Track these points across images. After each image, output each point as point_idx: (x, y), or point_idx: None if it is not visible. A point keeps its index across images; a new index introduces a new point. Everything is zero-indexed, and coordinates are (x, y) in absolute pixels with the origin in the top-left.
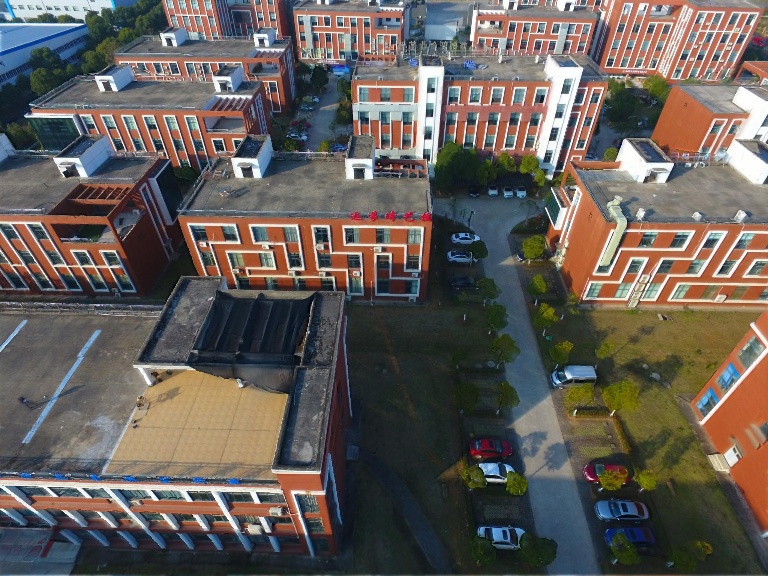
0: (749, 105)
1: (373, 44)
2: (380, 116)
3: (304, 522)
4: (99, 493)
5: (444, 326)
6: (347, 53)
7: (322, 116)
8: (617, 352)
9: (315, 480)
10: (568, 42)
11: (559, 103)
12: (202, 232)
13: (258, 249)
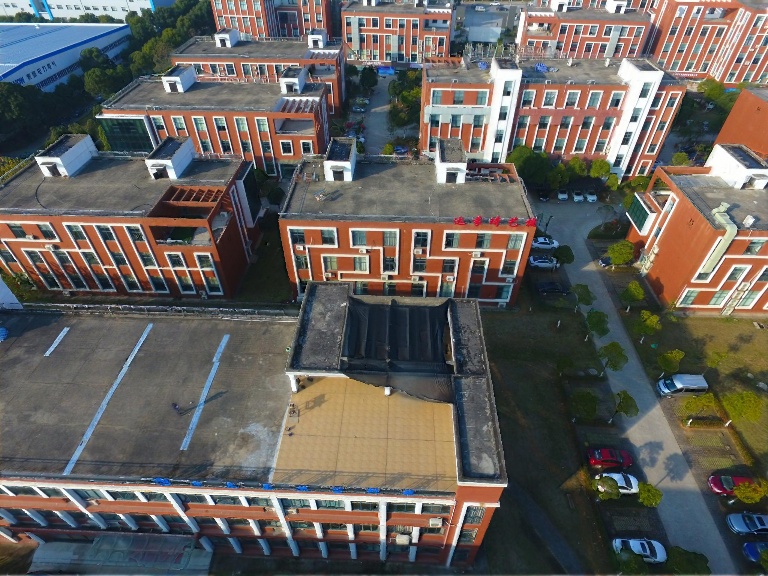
0: None
1: (420, 46)
2: (451, 119)
3: (459, 533)
4: (258, 501)
5: (538, 332)
6: (393, 55)
7: (374, 118)
8: (719, 361)
9: (496, 493)
10: (619, 45)
11: (636, 107)
12: (300, 235)
13: (354, 253)
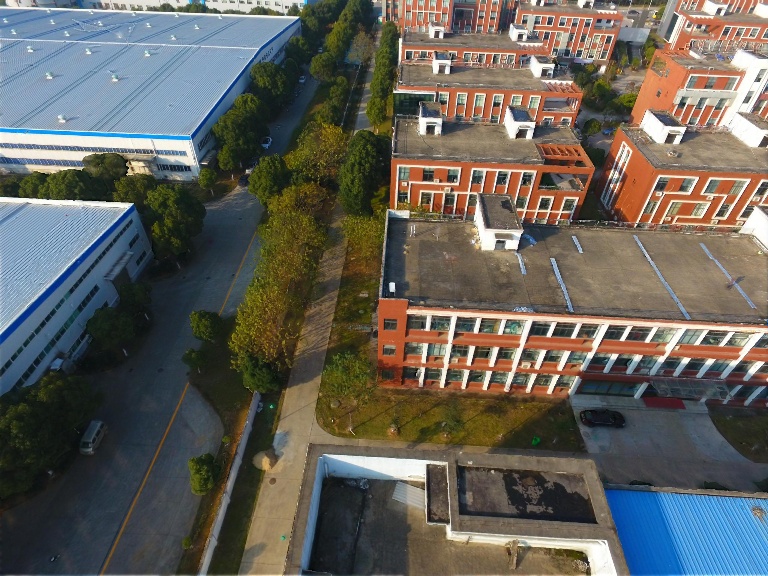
0: None
1: (588, 43)
2: None
3: None
4: None
5: None
6: (561, 50)
7: None
8: None
9: None
10: None
11: None
12: (663, 183)
13: (700, 200)
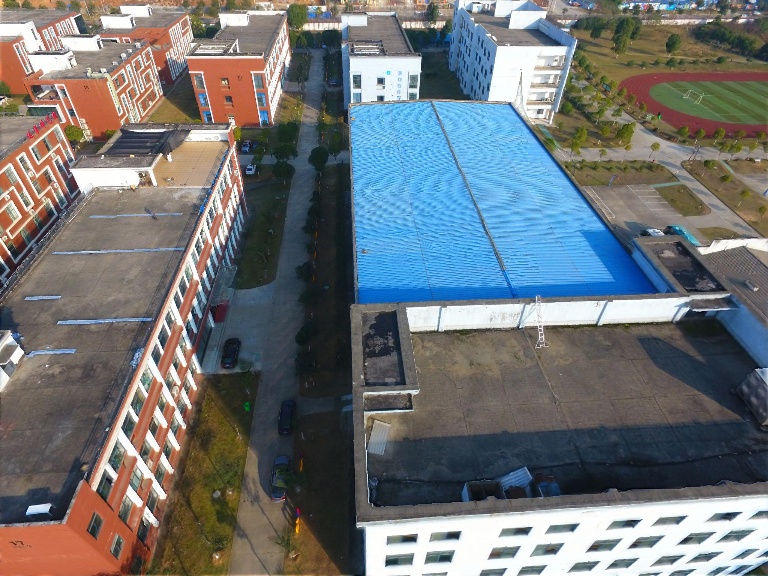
0: (16, 31)
1: None
2: None
3: (240, 178)
4: None
5: None
6: None
7: None
8: None
9: None
10: None
11: None
12: None
13: (3, 205)
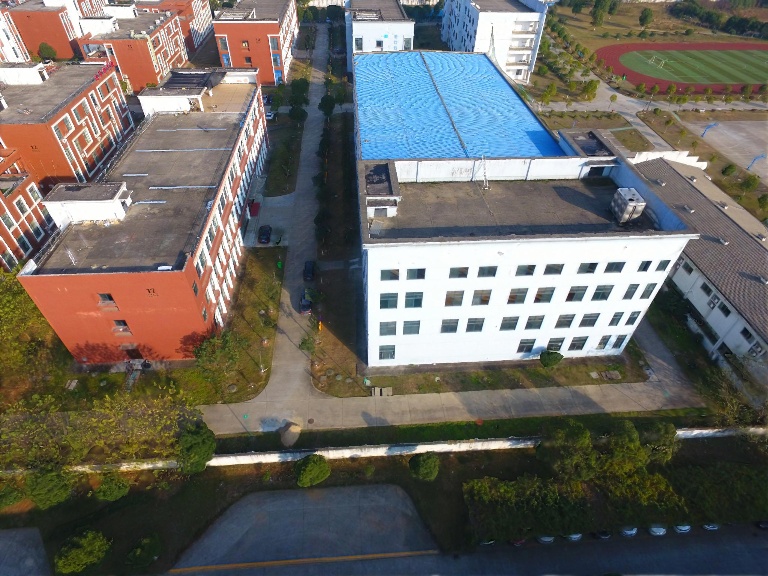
0: (60, 2)
1: None
2: None
3: (264, 115)
4: None
5: None
6: None
7: None
8: None
9: None
10: None
11: (2, 29)
12: None
13: (81, 129)
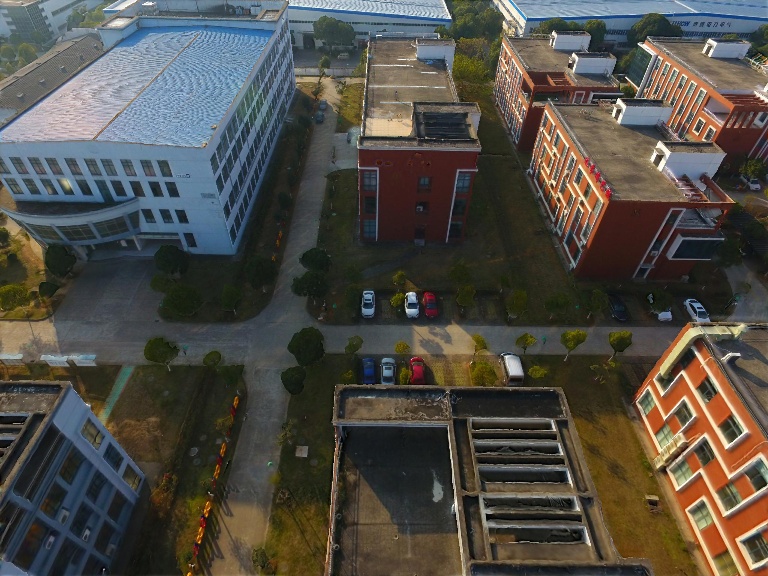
0: None
1: None
2: None
3: None
4: None
5: (548, 289)
6: None
7: None
8: None
9: None
10: None
11: None
12: None
13: None
